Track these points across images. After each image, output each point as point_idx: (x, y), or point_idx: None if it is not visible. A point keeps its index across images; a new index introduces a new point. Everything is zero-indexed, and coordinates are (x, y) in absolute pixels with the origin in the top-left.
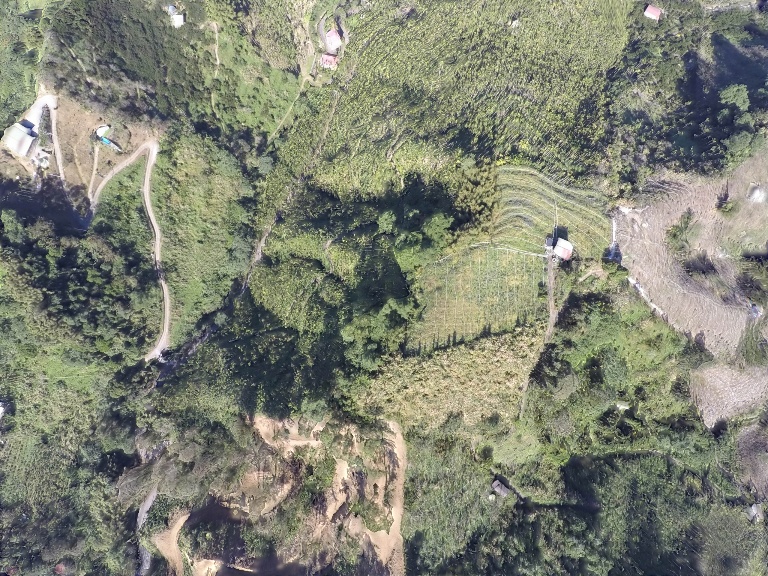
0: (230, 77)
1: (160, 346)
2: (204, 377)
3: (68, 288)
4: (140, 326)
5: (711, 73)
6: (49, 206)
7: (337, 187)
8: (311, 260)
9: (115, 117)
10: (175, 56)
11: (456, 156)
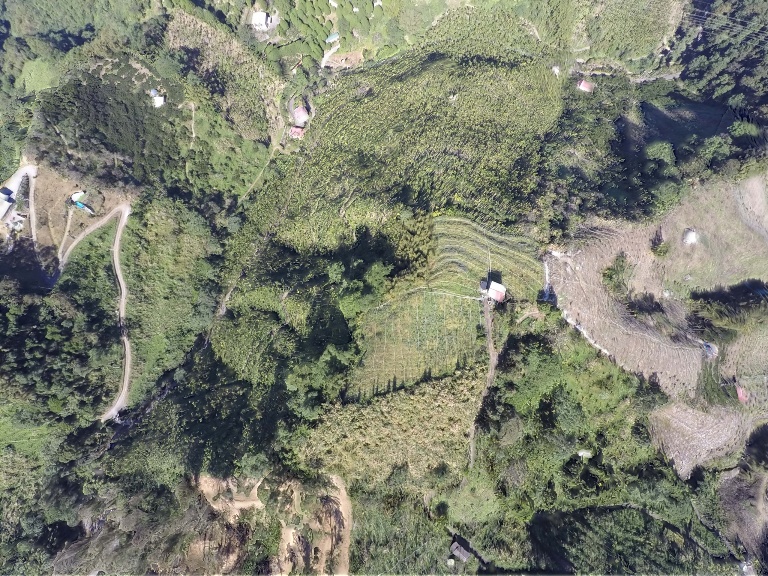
0: (204, 148)
1: (118, 405)
2: (156, 436)
3: (25, 346)
4: (98, 384)
5: (644, 135)
6: (18, 266)
7: (298, 243)
8: (269, 312)
9: (90, 184)
10: (154, 131)
11: (398, 210)
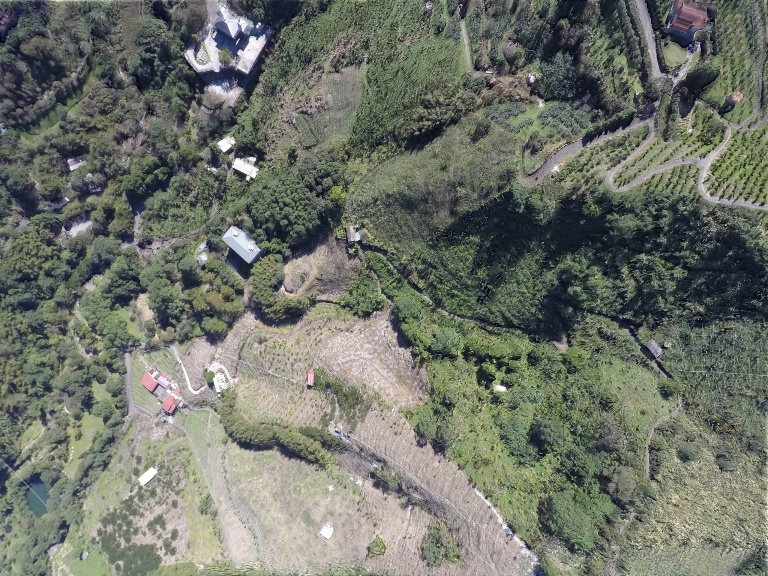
0: None
1: None
2: None
3: None
4: None
5: None
6: None
7: None
8: None
9: None
10: None
11: None
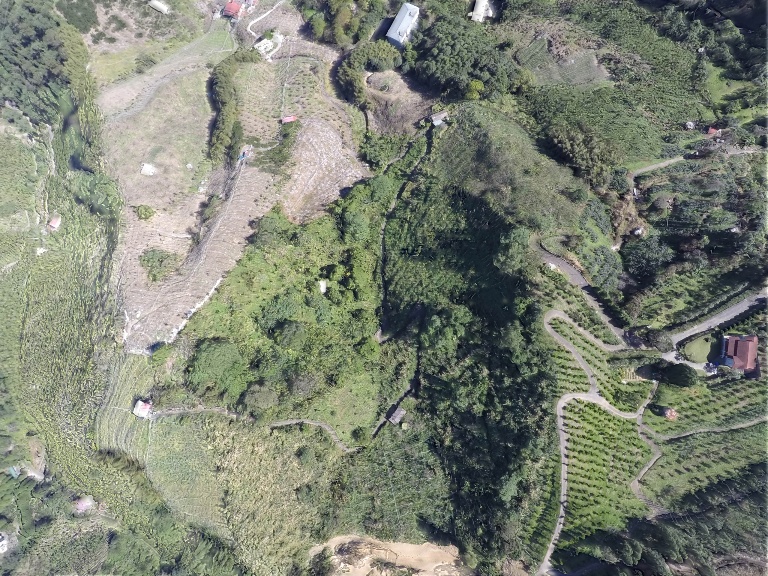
0: None
1: None
2: None
3: None
4: None
5: None
6: None
7: None
8: None
9: None
10: None
11: None
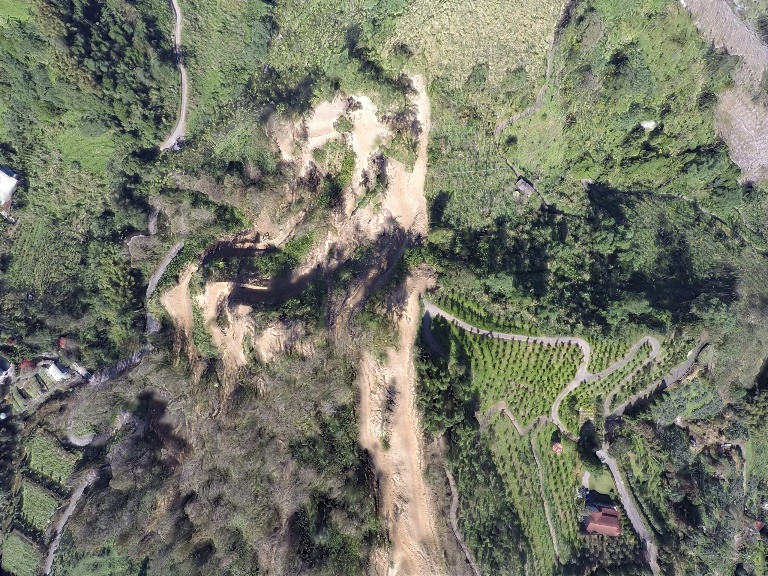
0: None
1: (176, 134)
2: None
3: (90, 36)
4: (157, 104)
5: None
6: None
7: None
8: None
9: None
10: None
11: None
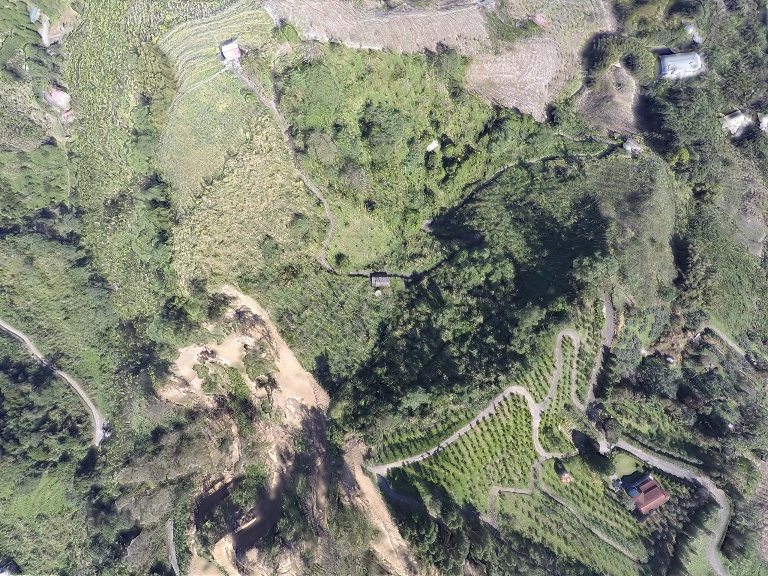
0: None
1: (98, 424)
2: None
3: None
4: (64, 418)
5: None
6: None
7: None
8: None
9: None
10: None
11: None
